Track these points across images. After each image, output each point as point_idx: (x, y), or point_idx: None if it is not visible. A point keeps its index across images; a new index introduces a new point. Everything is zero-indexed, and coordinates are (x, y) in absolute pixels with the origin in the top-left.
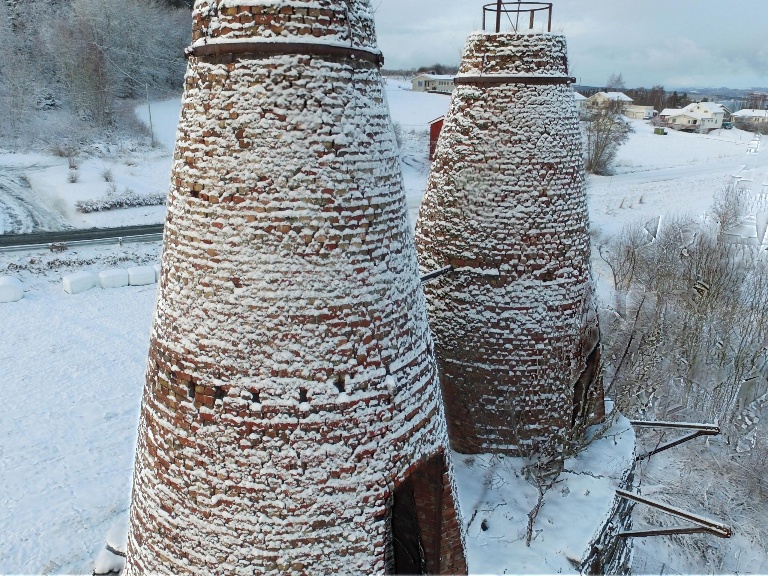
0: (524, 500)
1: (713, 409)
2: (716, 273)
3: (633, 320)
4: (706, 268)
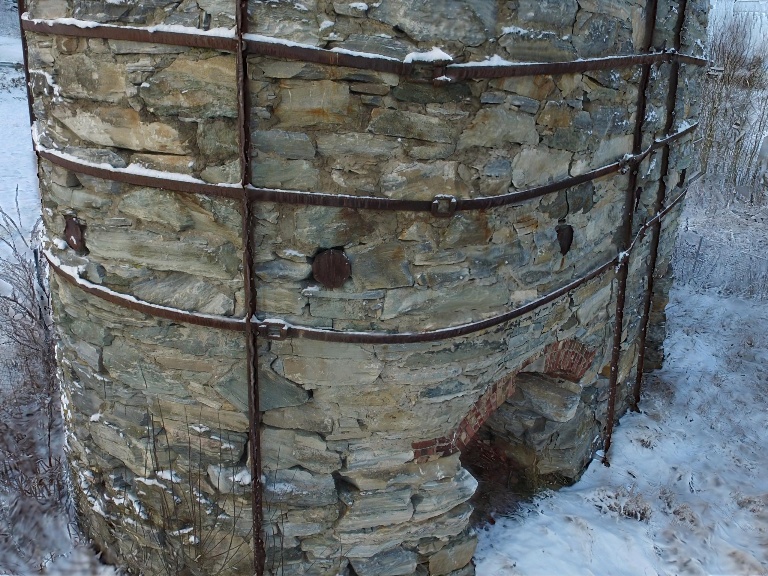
0: None
1: (735, 167)
2: (732, 49)
3: None
4: (720, 49)
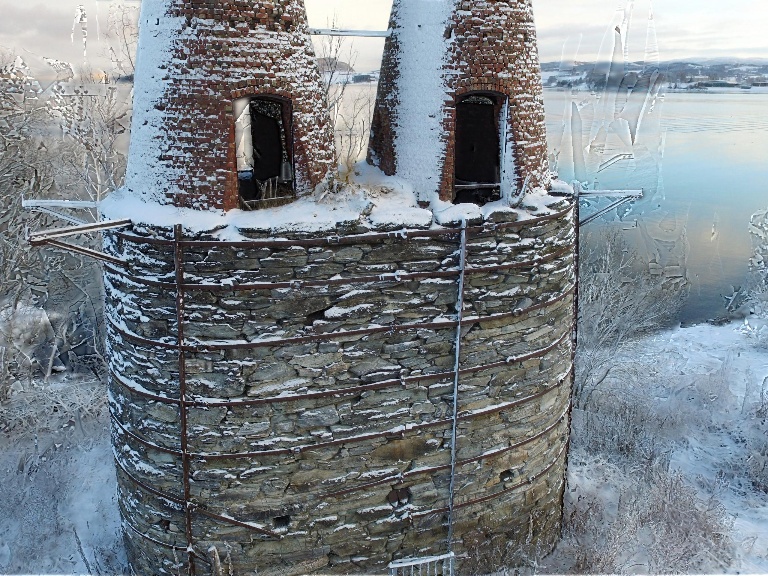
0: None
1: None
2: None
3: None
4: None
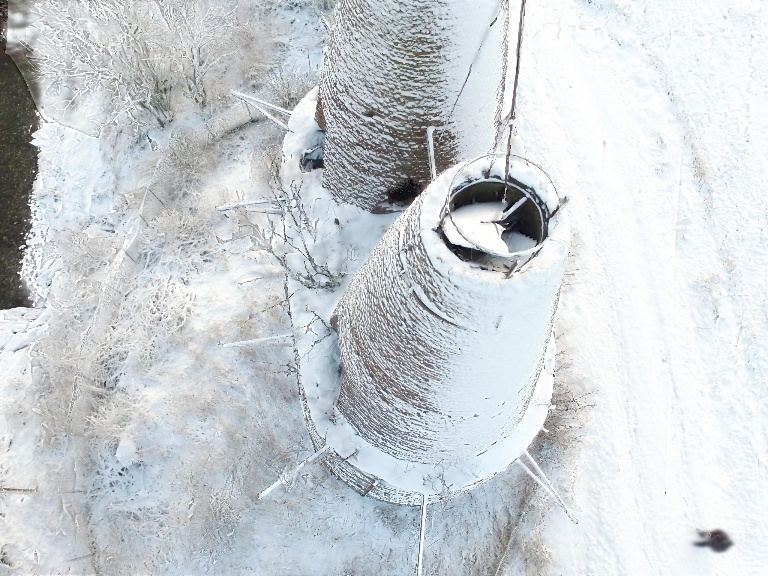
0: (331, 256)
1: None
2: None
3: None
4: None
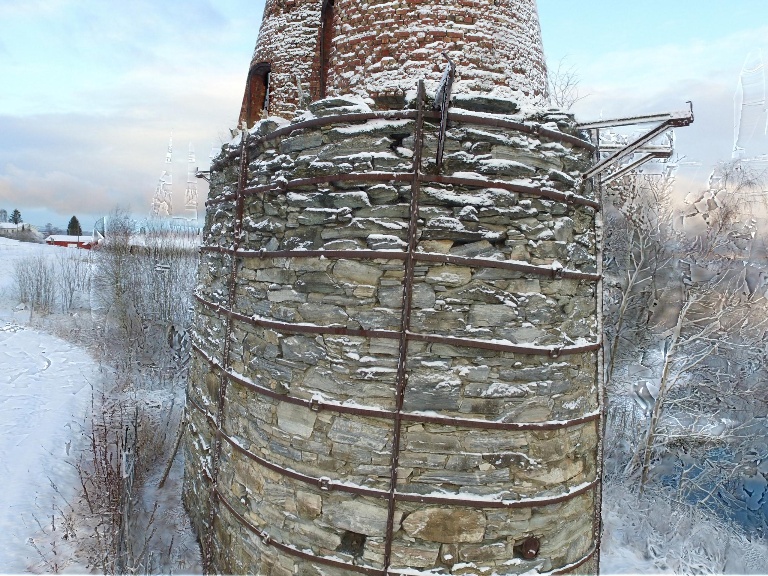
0: None
1: None
2: (174, 252)
3: (99, 318)
4: (163, 251)
